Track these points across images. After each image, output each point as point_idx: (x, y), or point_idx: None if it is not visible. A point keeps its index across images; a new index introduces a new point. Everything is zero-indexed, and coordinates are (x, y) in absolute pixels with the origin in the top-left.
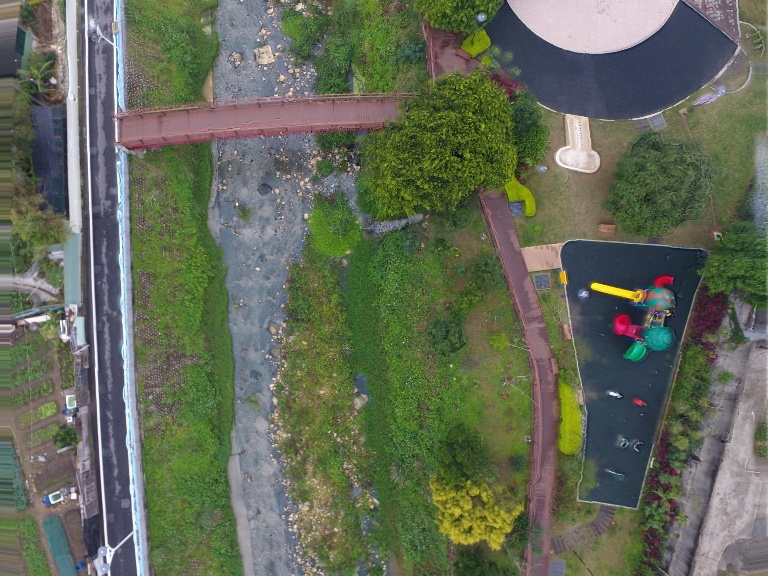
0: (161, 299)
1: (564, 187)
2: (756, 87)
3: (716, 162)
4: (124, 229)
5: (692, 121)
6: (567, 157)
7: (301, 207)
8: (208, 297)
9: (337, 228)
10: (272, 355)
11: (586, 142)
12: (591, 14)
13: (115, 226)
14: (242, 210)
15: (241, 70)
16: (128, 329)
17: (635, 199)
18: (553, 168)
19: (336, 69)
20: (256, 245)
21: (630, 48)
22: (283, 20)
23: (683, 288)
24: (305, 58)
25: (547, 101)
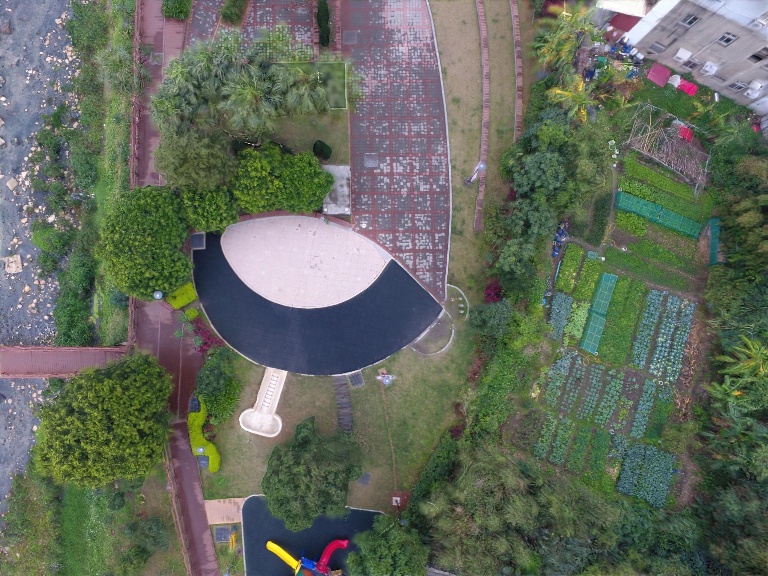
0: None
1: (246, 447)
2: (455, 351)
3: (403, 427)
4: None
5: None
6: (251, 418)
7: (31, 418)
8: None
9: None
10: None
11: (273, 403)
12: (303, 268)
13: None
14: None
15: None
16: None
17: None
18: (237, 428)
19: (74, 288)
20: None
21: (337, 304)
22: (34, 231)
23: None
24: (50, 271)
25: (250, 352)
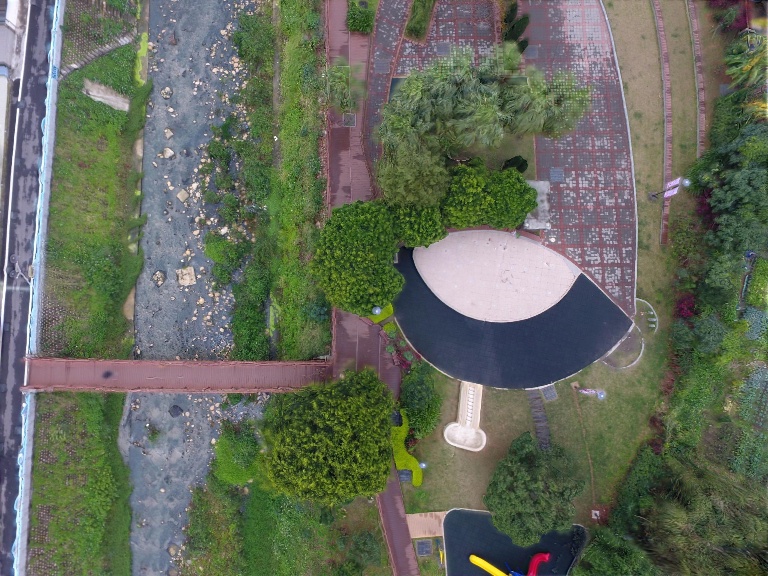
0: (60, 529)
1: (450, 462)
2: (646, 365)
3: (600, 440)
4: (24, 471)
5: (582, 396)
6: (455, 433)
7: (210, 431)
8: (111, 516)
9: (240, 461)
10: (169, 575)
11: (475, 417)
12: (495, 282)
13: (15, 468)
14: (152, 430)
15: (163, 289)
16: (19, 573)
17: (501, 513)
18: (441, 442)
19: (253, 301)
20: (163, 466)
21: (529, 318)
22: (208, 244)
23: (558, 563)
24: (225, 284)
25: (445, 366)
